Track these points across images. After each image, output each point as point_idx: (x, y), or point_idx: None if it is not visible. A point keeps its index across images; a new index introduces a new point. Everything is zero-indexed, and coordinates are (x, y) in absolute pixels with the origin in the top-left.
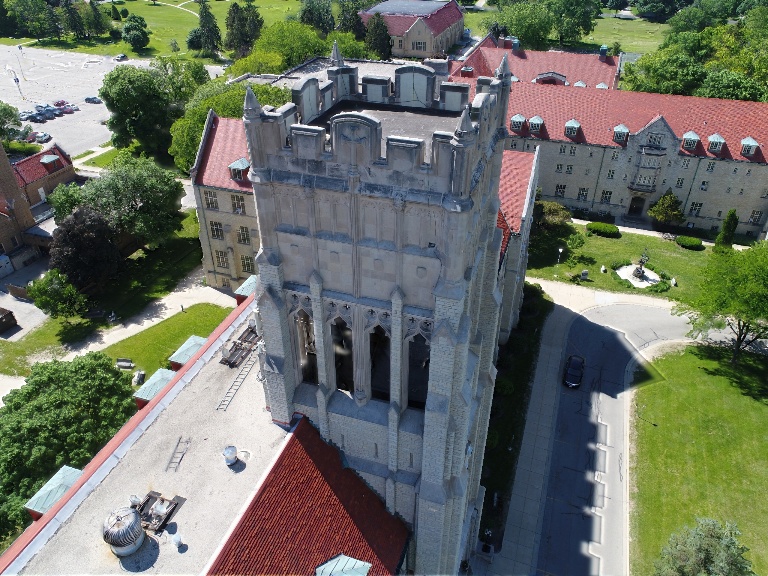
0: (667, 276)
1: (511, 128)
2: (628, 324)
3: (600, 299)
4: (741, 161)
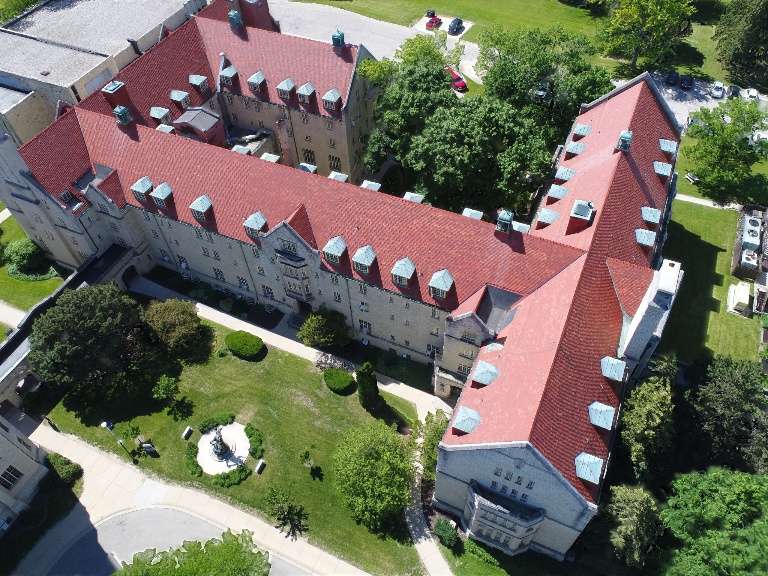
0: (257, 454)
1: (136, 197)
2: (141, 551)
3: (142, 495)
4: (392, 293)
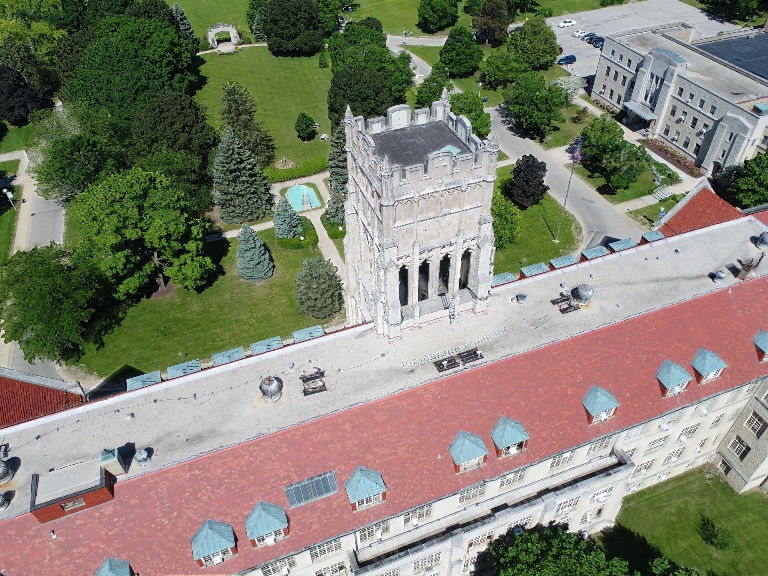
0: None
1: None
2: None
3: None
4: None
